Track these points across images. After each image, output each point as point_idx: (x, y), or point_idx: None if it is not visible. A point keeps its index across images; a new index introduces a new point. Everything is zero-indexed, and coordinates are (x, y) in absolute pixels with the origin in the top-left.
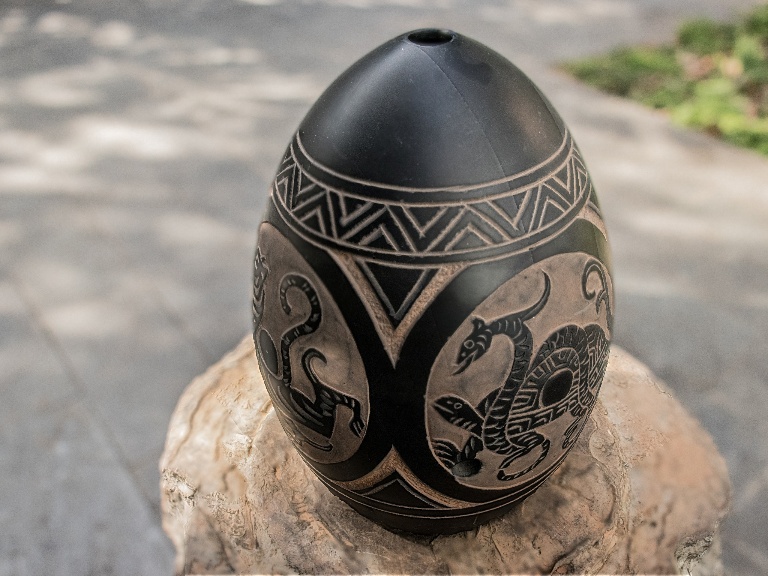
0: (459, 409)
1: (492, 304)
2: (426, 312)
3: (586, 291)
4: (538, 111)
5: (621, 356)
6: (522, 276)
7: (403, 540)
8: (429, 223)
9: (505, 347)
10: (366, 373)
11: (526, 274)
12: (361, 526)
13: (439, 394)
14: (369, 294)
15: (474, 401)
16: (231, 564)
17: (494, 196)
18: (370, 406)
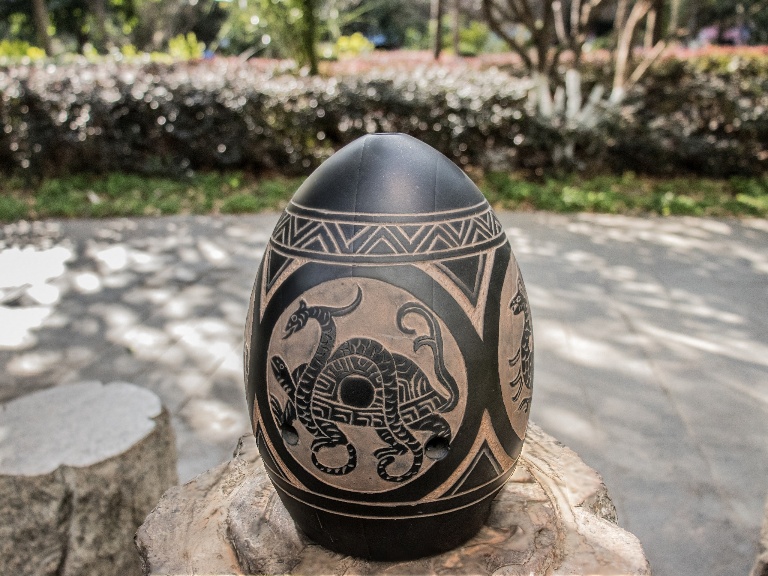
0: (282, 370)
1: (314, 294)
2: (280, 287)
3: (401, 323)
4: (417, 186)
5: (633, 545)
6: (340, 282)
7: (295, 533)
8: (301, 229)
9: (315, 330)
10: (252, 327)
11: (344, 282)
12: (285, 513)
13: (275, 353)
14: (266, 271)
15: (291, 367)
16: (208, 494)
17: (342, 221)
18: (250, 354)
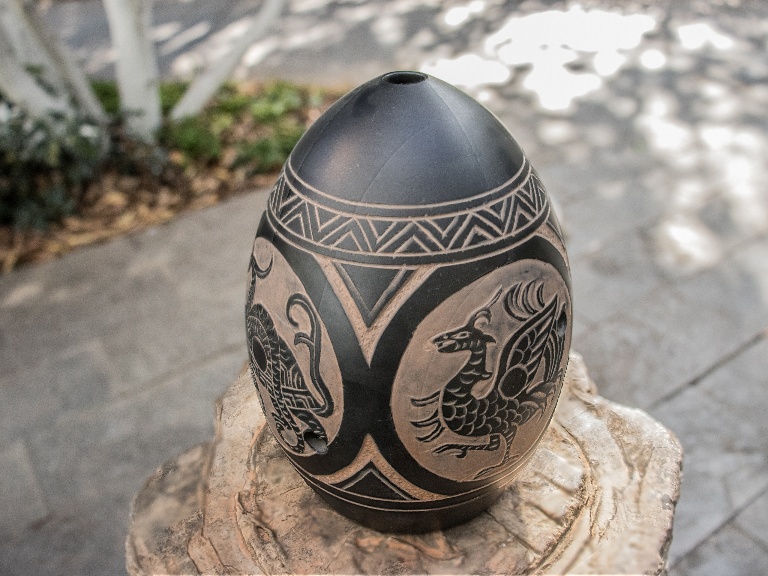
0: None
1: None
2: None
3: (290, 311)
4: (359, 163)
5: None
6: None
7: None
8: None
9: None
10: None
11: None
12: None
13: None
14: None
15: None
16: None
17: None
18: None
